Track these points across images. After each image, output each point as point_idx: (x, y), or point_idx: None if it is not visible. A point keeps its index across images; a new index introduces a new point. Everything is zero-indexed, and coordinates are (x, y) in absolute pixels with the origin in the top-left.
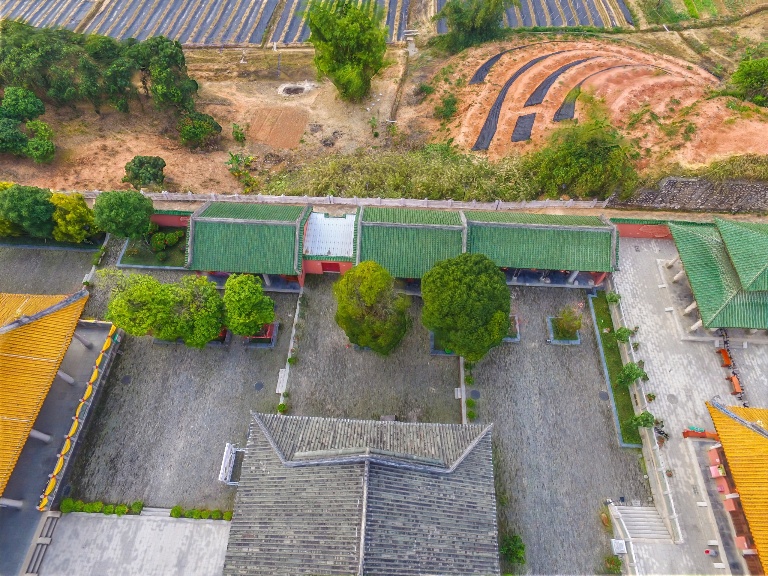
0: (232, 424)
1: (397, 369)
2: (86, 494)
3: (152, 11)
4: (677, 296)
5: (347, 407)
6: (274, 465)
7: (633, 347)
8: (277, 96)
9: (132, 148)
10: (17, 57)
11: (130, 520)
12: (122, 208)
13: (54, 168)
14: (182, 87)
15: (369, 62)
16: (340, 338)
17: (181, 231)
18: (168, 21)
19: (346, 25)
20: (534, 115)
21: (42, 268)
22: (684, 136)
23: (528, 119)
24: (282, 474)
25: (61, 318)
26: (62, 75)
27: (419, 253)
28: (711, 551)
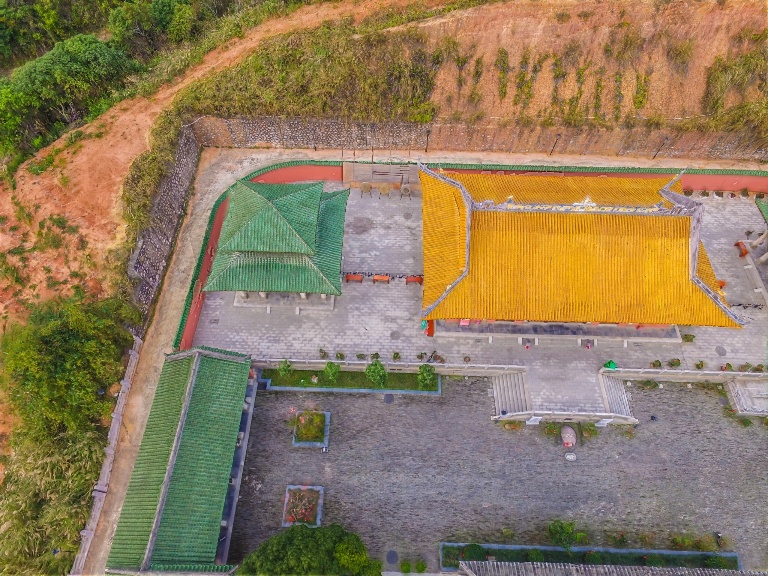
0: None
1: None
2: None
3: None
4: (283, 299)
5: None
6: None
7: (340, 359)
8: None
9: None
10: None
11: None
12: None
13: None
14: None
15: None
16: None
17: None
18: None
19: None
20: None
21: None
22: (68, 232)
23: None
24: None
25: None
26: None
27: None
28: (528, 345)
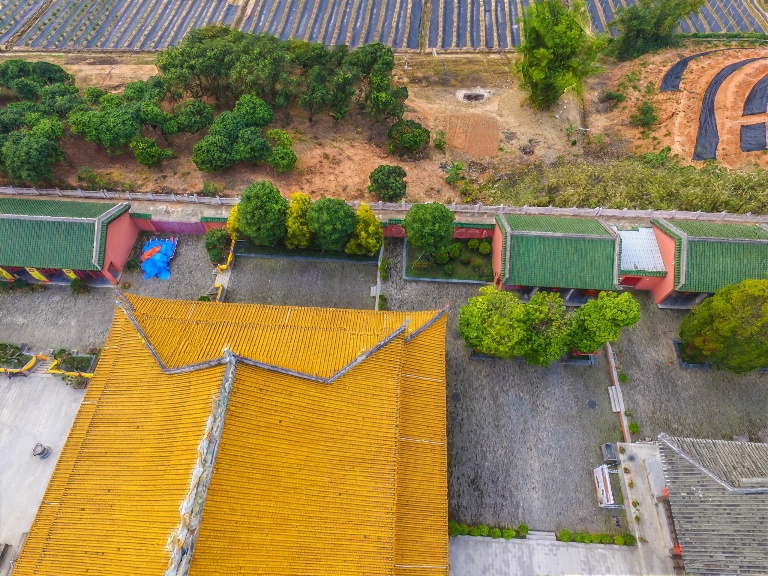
0: (580, 444)
1: (729, 387)
2: (461, 516)
3: (299, 15)
4: None
5: (694, 427)
6: (715, 491)
7: None
8: (459, 103)
9: (352, 156)
10: (249, 64)
11: (519, 544)
12: (443, 221)
13: (287, 177)
14: (395, 94)
15: (577, 70)
16: (659, 355)
17: (459, 243)
18: (318, 26)
19: (564, 32)
20: (764, 125)
21: (324, 280)
22: None
23: (756, 129)
24: (732, 501)
25: (432, 336)
26: (290, 82)
27: (744, 268)
28: None
